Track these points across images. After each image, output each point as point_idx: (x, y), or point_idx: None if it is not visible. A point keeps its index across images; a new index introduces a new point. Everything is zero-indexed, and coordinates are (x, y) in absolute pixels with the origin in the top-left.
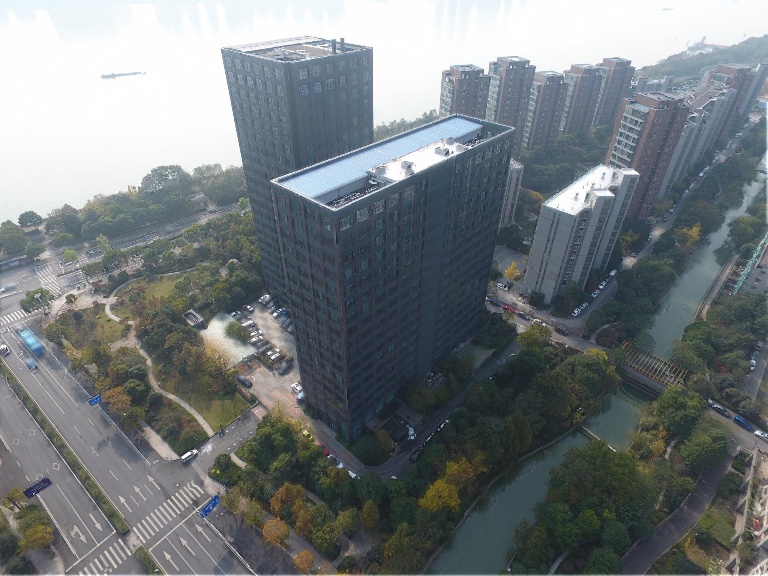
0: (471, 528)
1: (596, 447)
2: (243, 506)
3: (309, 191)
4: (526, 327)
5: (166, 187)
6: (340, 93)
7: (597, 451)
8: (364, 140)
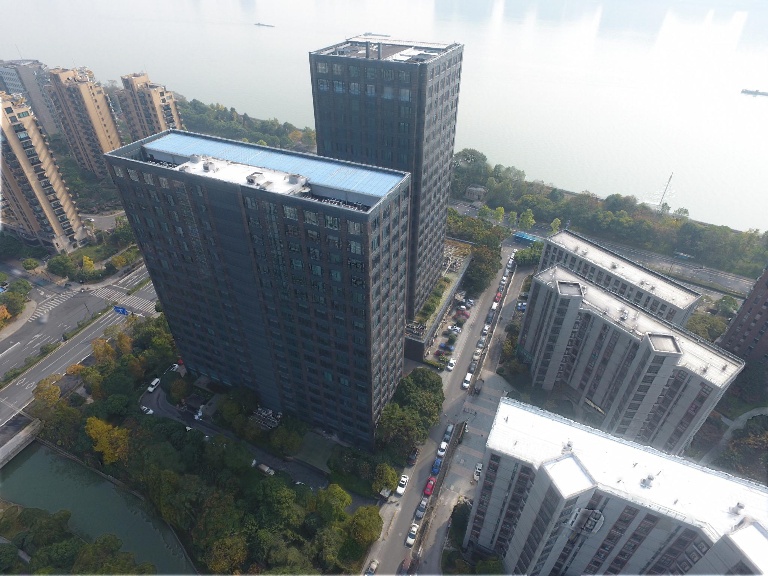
0: (105, 490)
1: (109, 570)
2: (121, 326)
3: (158, 144)
4: (398, 515)
5: (460, 167)
6: (368, 102)
7: (103, 572)
8: (400, 168)
